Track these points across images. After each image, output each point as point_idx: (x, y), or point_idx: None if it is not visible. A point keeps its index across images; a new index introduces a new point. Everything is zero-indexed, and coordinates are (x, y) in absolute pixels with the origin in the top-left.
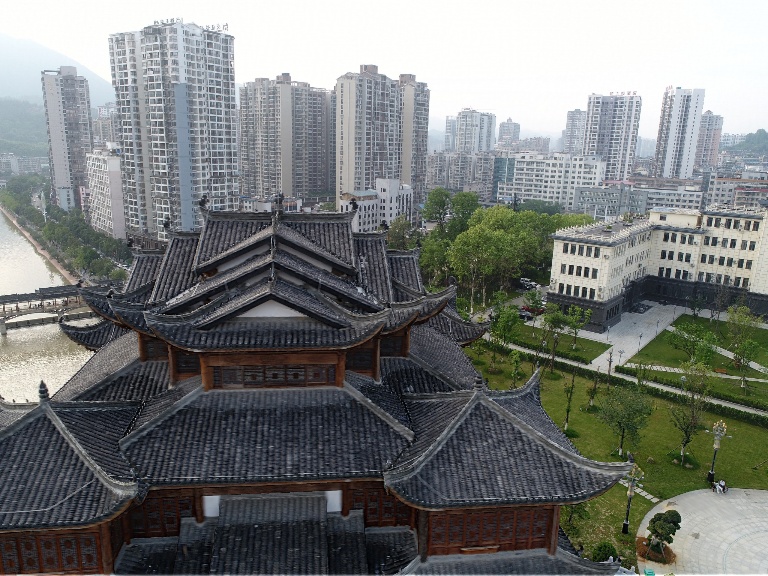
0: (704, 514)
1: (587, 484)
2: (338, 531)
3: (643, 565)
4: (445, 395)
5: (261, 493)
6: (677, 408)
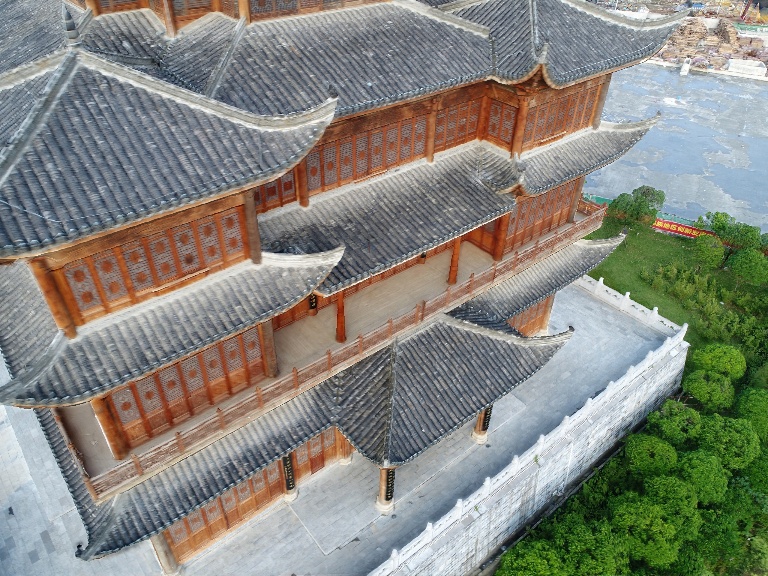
0: None
1: None
2: None
3: None
4: None
5: None
6: None
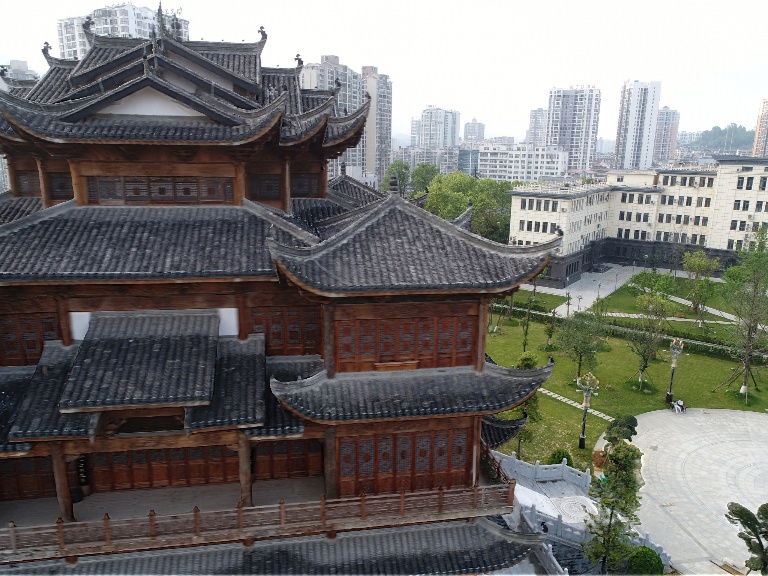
0: (662, 430)
1: (512, 270)
2: (233, 353)
3: (600, 474)
4: (359, 210)
5: (140, 310)
6: (634, 333)
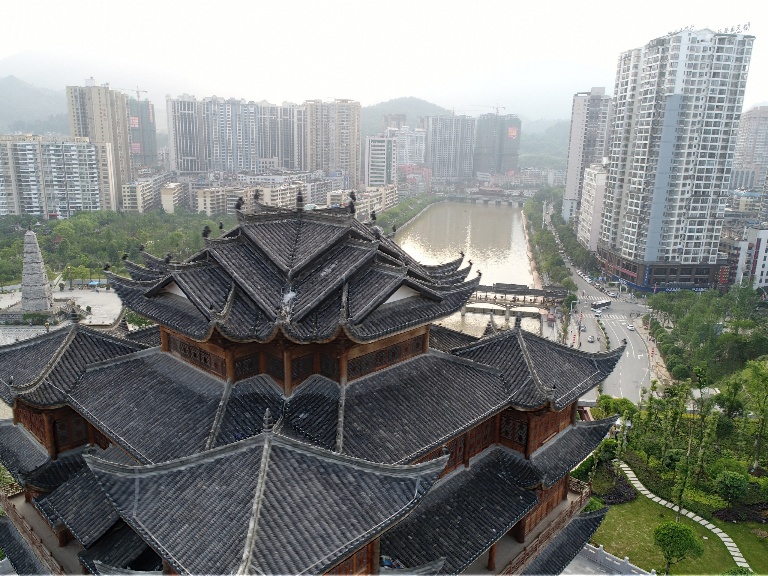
0: None
1: None
2: None
3: None
4: None
5: None
6: None
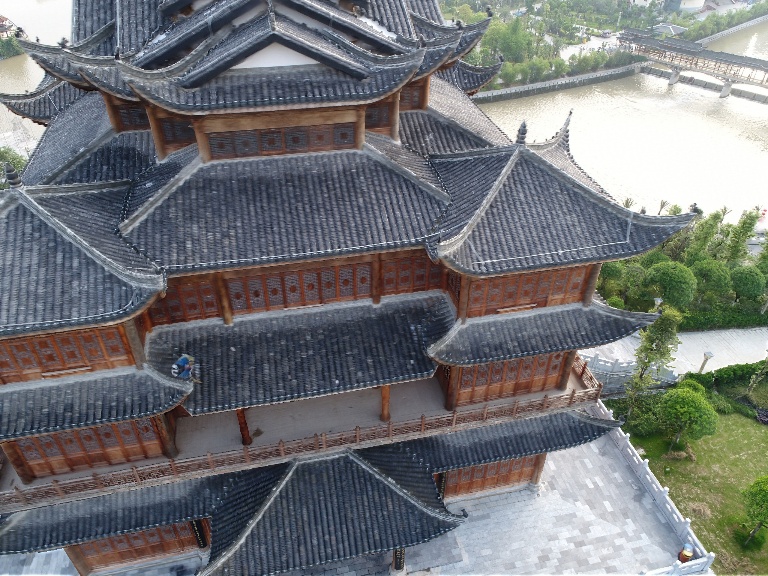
0: None
1: None
2: None
3: None
4: None
5: None
6: None
